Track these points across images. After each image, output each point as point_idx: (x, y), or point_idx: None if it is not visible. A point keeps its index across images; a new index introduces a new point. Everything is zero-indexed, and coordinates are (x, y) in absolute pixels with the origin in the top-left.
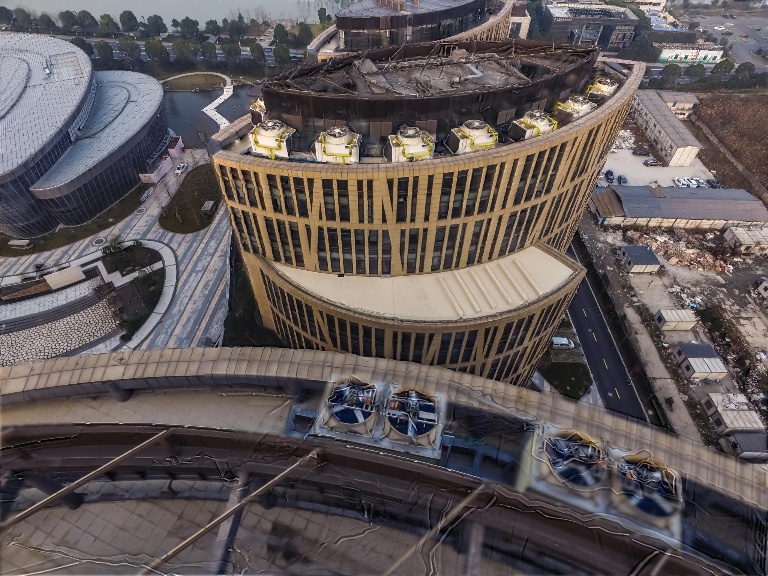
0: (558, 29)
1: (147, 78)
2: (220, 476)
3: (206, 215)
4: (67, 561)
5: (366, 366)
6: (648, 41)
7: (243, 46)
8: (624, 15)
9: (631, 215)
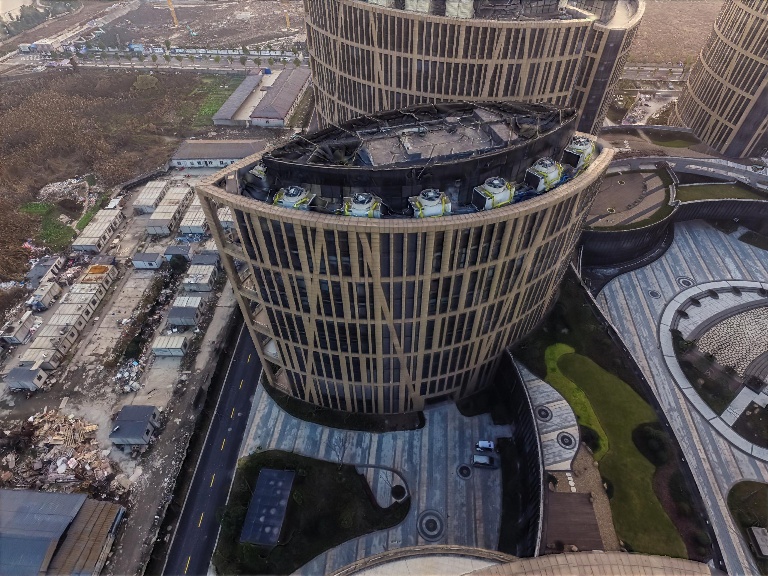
0: None
1: None
2: (491, 18)
3: (750, 523)
4: (509, 3)
5: (464, 19)
6: None
7: None
8: None
9: (79, 497)
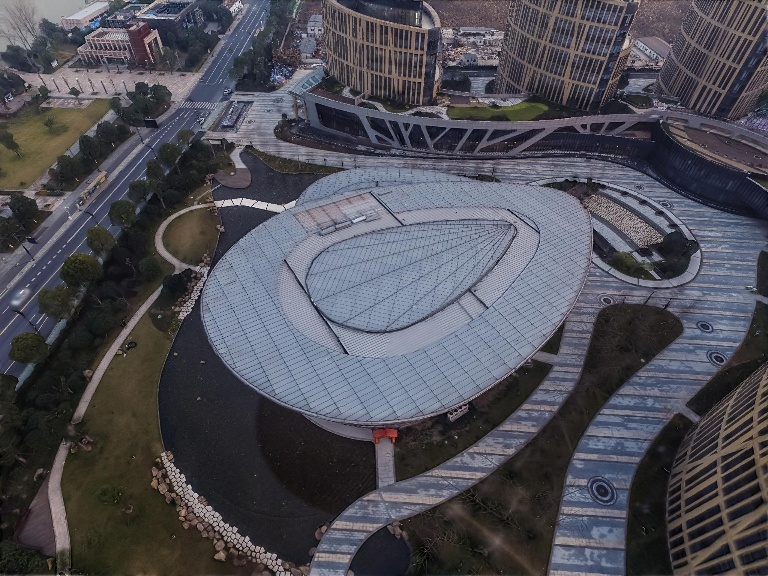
0: (179, 28)
1: (321, 183)
2: None
3: None
4: None
5: None
6: (225, 8)
7: (44, 219)
8: (177, 2)
9: None
